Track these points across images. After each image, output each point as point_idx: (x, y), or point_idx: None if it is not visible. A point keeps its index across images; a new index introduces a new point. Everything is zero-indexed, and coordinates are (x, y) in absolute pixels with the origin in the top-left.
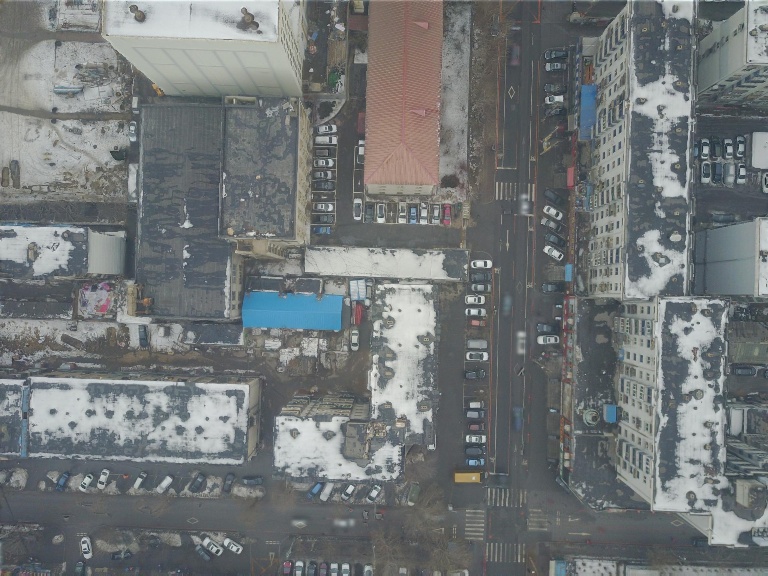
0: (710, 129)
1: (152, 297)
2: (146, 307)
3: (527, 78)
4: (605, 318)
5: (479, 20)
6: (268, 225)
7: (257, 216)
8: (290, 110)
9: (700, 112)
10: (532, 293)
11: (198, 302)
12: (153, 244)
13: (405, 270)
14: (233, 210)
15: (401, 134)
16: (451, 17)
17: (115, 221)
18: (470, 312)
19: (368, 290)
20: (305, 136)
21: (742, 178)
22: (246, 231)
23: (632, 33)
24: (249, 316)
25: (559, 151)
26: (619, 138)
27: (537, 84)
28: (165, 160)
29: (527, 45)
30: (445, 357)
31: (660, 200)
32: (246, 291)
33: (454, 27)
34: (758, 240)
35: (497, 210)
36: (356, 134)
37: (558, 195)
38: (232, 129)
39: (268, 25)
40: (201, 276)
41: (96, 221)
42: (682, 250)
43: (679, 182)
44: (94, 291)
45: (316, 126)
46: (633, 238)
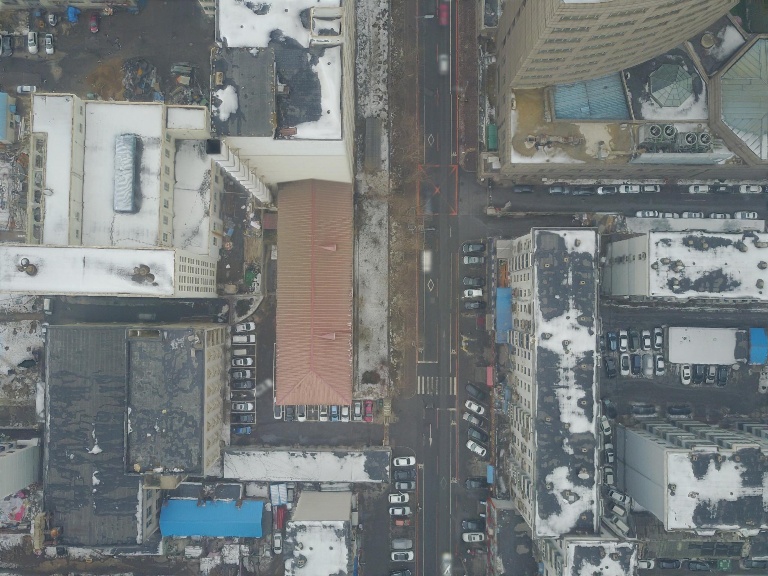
0: (628, 320)
1: (61, 525)
2: (54, 539)
3: (446, 270)
4: (525, 528)
5: (396, 213)
6: (176, 460)
7: (164, 451)
8: (196, 342)
9: (618, 303)
10: (456, 489)
11: (109, 529)
12: (61, 470)
13: (326, 473)
14: (139, 445)
15: (310, 362)
16: (368, 210)
17: (29, 425)
18: (394, 512)
19: (289, 493)
20: (216, 356)
21: (660, 370)
22: (153, 467)
23: (535, 267)
24: (167, 526)
25: (479, 344)
26: (528, 364)
27: (456, 276)
28: (72, 383)
29: (445, 237)
30: (370, 557)
31: (568, 436)
32: (164, 499)
33: (371, 220)
34: (666, 474)
35: (419, 405)
36: (275, 331)
37: (479, 390)
38: (137, 362)
39: (164, 277)
40: (111, 502)
41: (9, 425)
42: (591, 486)
43: (586, 417)
44: (8, 500)
45: (234, 324)
46: (542, 475)
